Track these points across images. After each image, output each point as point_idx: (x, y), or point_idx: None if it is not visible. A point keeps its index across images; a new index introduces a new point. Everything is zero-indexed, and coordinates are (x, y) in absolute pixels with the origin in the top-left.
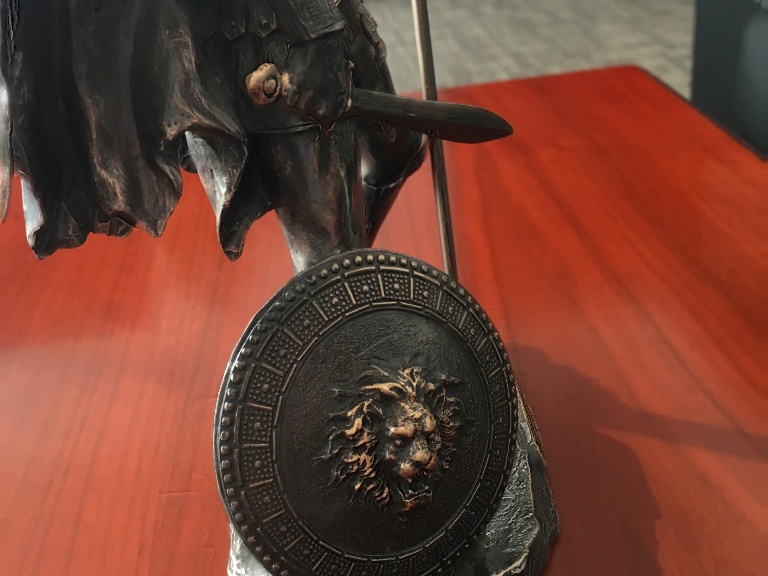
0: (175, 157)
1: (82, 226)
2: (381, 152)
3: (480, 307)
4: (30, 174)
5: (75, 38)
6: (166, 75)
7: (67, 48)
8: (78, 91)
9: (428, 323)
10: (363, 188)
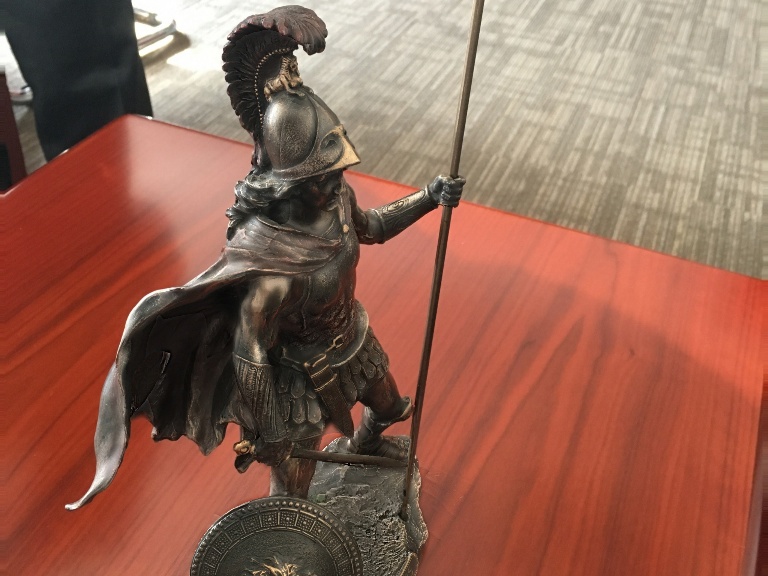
0: (224, 426)
1: (178, 434)
2: (376, 412)
3: (353, 543)
4: (153, 422)
5: (195, 366)
6: (229, 395)
7: (191, 368)
8: (191, 386)
9: (315, 545)
10: (368, 418)
